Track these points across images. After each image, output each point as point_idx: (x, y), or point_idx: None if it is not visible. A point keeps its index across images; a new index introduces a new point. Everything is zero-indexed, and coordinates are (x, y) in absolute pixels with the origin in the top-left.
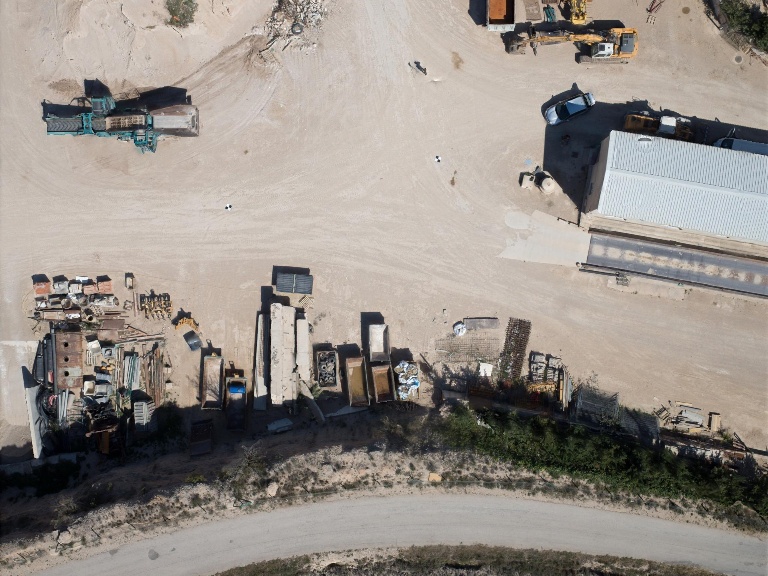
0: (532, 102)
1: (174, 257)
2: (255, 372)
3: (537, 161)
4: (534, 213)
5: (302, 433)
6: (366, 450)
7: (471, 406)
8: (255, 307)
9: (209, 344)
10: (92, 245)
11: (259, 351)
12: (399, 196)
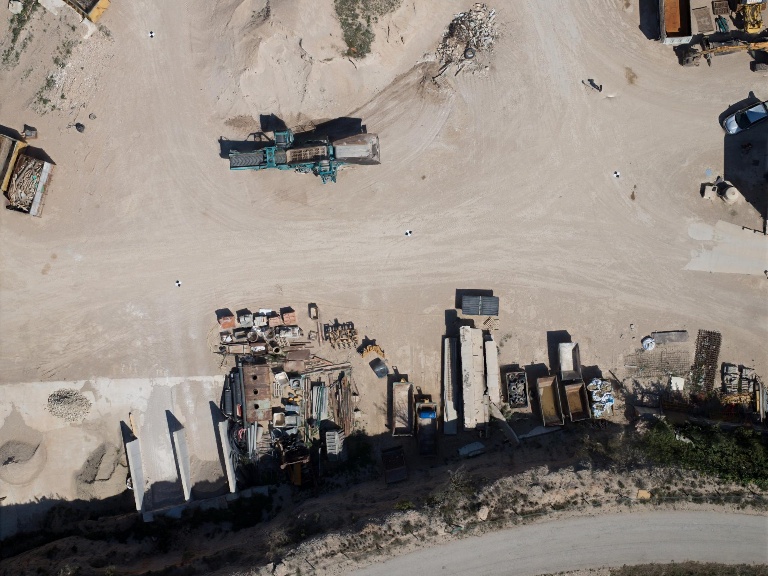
0: (709, 113)
1: (356, 285)
2: (444, 396)
3: (717, 171)
4: (718, 223)
5: (497, 456)
6: (573, 469)
7: (669, 421)
8: (440, 331)
9: (395, 370)
10: (274, 277)
11: (447, 375)
12: (579, 213)
